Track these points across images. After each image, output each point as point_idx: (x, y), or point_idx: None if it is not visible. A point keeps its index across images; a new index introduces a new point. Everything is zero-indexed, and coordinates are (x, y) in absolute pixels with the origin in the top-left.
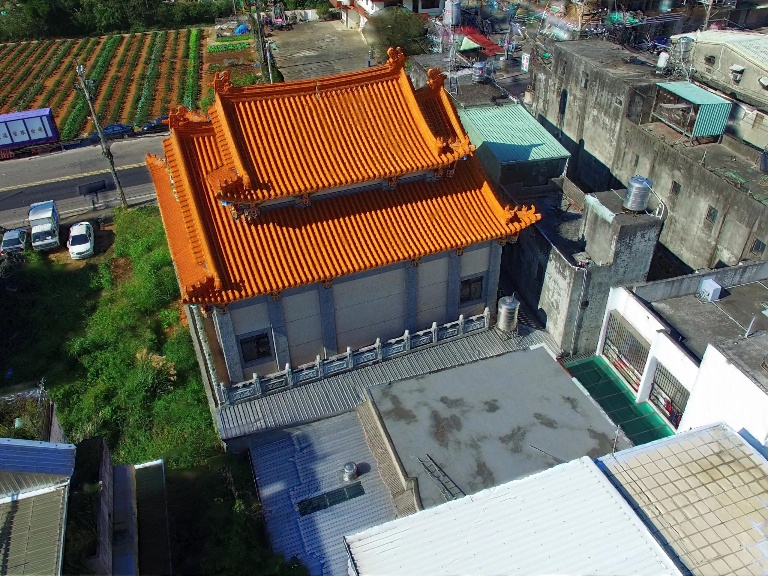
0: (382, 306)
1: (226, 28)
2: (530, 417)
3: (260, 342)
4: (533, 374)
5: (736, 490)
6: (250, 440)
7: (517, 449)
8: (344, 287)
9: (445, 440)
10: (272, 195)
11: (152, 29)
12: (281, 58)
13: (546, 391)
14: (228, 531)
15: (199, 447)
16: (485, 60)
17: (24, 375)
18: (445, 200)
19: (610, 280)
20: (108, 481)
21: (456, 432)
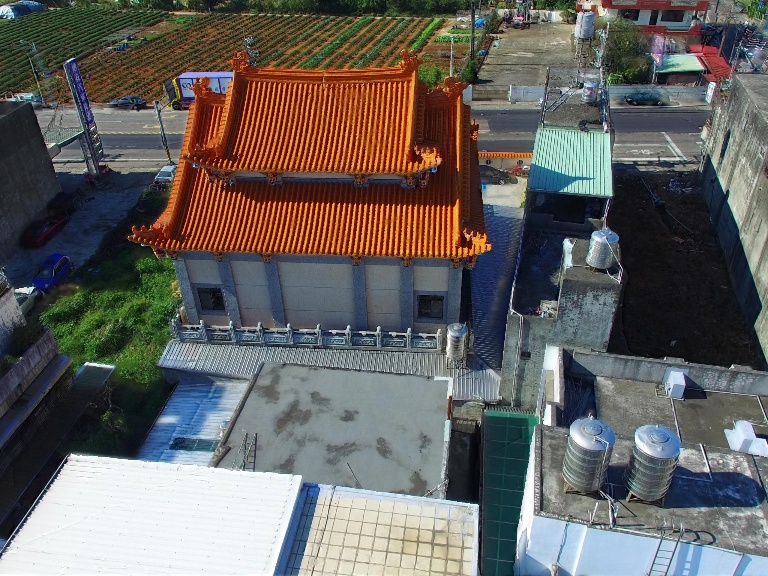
0: (331, 296)
1: (467, 21)
2: (373, 438)
3: (216, 295)
4: (414, 402)
5: (413, 571)
6: (180, 375)
7: (333, 461)
8: (291, 267)
9: (282, 428)
10: (234, 167)
11: (403, 15)
12: (494, 55)
13: (411, 422)
14: (96, 433)
15: (158, 369)
16: (703, 85)
17: (103, 276)
18: (410, 209)
19: (556, 337)
20: (38, 361)
21: (297, 425)
